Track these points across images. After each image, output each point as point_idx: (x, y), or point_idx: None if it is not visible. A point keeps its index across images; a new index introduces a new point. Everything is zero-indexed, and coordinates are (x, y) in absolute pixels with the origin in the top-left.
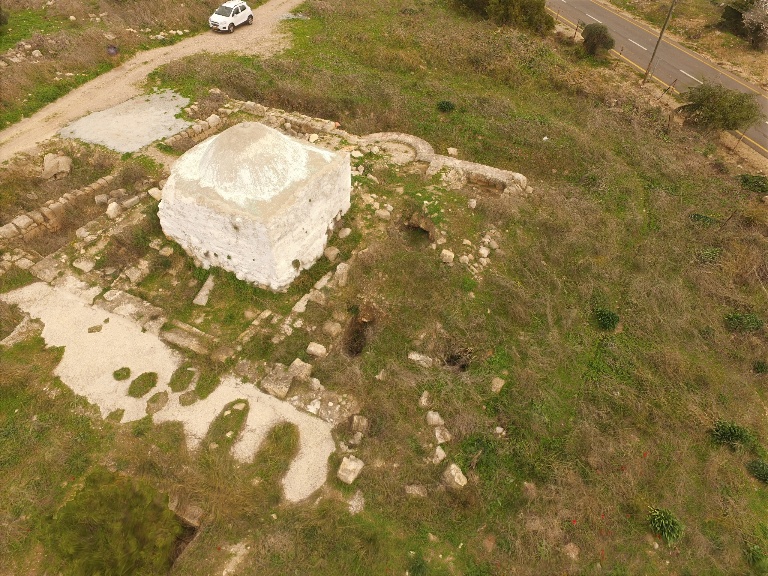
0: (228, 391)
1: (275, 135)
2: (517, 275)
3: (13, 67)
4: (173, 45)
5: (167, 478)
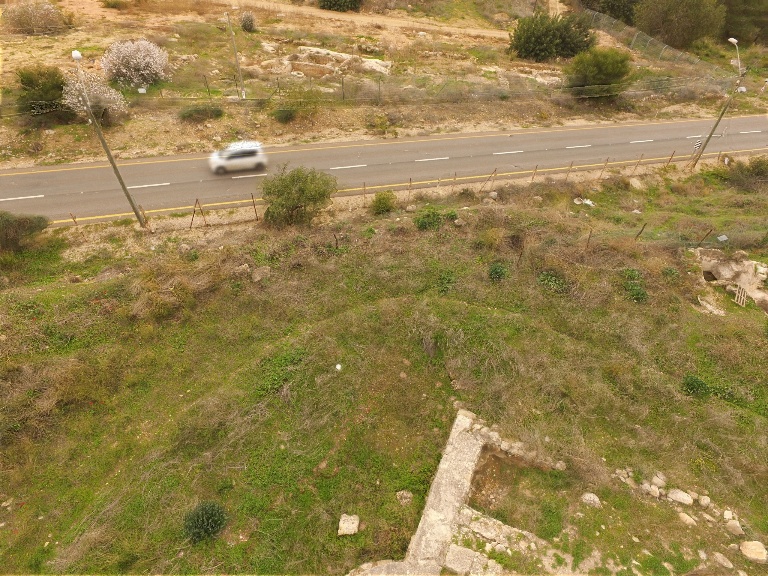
0: None
1: None
2: (687, 461)
3: None
4: None
5: None
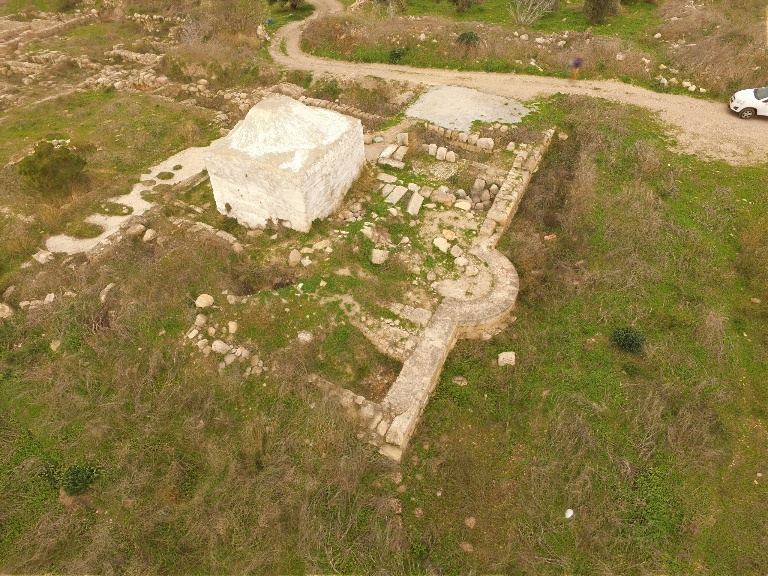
0: (142, 206)
1: (274, 117)
2: None
3: (516, 41)
4: (658, 93)
5: (92, 193)
